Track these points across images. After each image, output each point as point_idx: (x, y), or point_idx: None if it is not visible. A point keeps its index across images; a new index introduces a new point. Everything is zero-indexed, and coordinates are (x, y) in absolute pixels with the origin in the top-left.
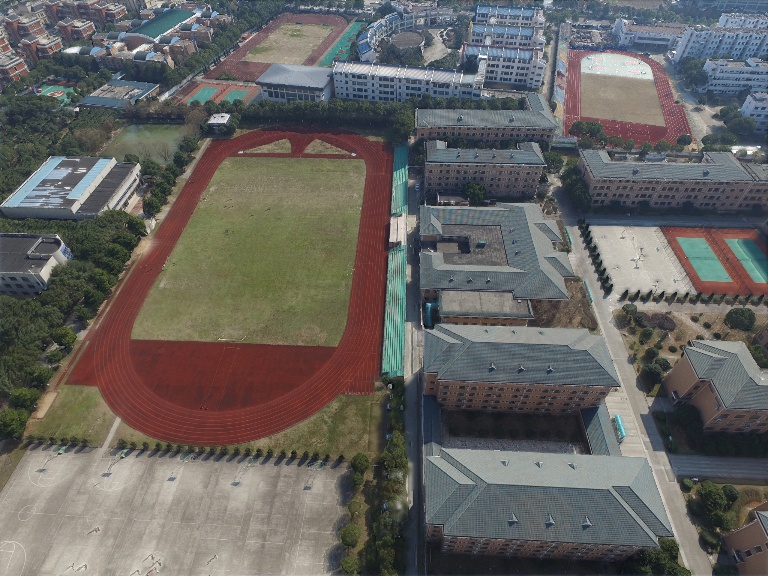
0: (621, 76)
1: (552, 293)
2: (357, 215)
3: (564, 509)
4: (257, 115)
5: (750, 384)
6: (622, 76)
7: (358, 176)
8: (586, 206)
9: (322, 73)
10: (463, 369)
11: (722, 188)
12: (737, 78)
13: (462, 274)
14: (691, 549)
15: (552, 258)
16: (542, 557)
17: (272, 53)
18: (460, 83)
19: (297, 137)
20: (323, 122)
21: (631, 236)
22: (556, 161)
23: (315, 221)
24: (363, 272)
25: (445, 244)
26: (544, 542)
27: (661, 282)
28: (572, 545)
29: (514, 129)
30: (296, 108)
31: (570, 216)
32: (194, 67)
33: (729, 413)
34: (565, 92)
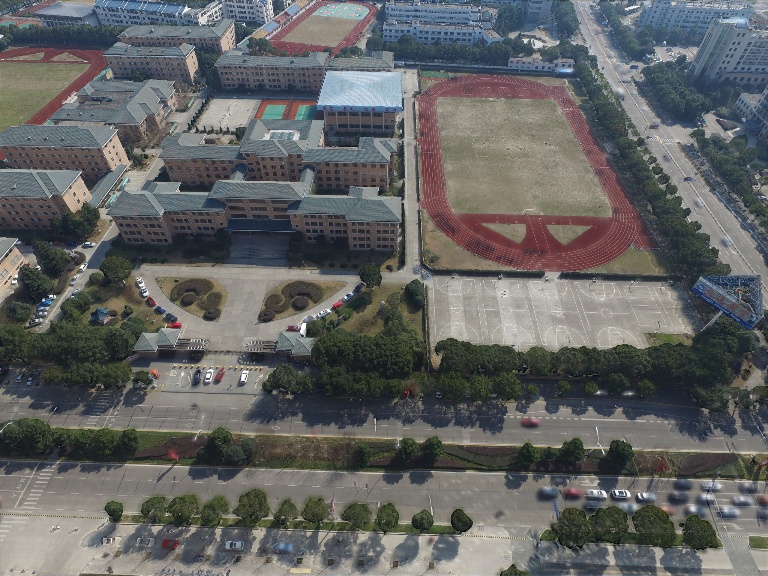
0: (339, 17)
1: (129, 121)
2: (57, 93)
3: (5, 182)
4: (25, 36)
5: (176, 145)
6: (339, 17)
7: (78, 73)
8: (213, 85)
9: (88, 8)
10: (12, 139)
11: (307, 73)
12: (407, 15)
13: (77, 111)
14: (116, 227)
15: (143, 103)
16: (27, 229)
17: (79, 0)
18: (183, 14)
19: (52, 51)
20: (79, 42)
21: (237, 104)
22: (208, 59)
23: (24, 96)
24: (34, 120)
25: (91, 102)
26: (4, 205)
27: (230, 125)
28: (20, 207)
29: (190, 39)
30: (54, 30)
31: (207, 94)
32: (0, 6)
33: (171, 165)
34: (279, 25)
